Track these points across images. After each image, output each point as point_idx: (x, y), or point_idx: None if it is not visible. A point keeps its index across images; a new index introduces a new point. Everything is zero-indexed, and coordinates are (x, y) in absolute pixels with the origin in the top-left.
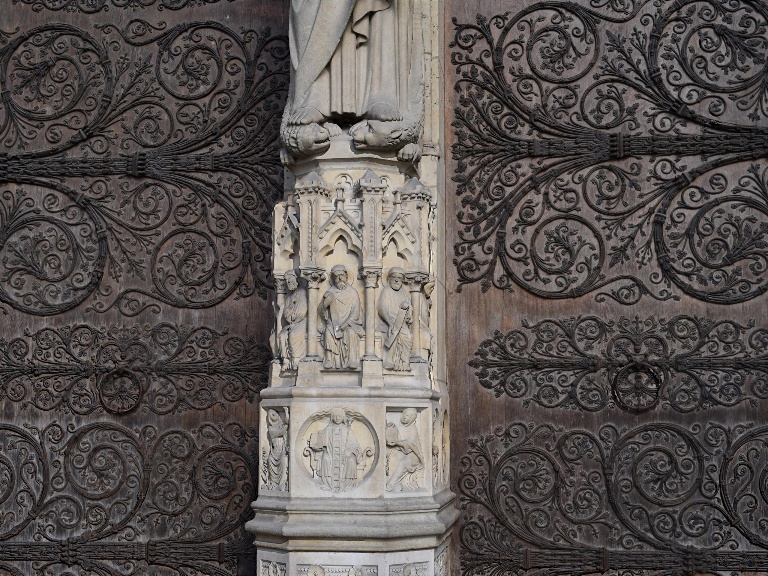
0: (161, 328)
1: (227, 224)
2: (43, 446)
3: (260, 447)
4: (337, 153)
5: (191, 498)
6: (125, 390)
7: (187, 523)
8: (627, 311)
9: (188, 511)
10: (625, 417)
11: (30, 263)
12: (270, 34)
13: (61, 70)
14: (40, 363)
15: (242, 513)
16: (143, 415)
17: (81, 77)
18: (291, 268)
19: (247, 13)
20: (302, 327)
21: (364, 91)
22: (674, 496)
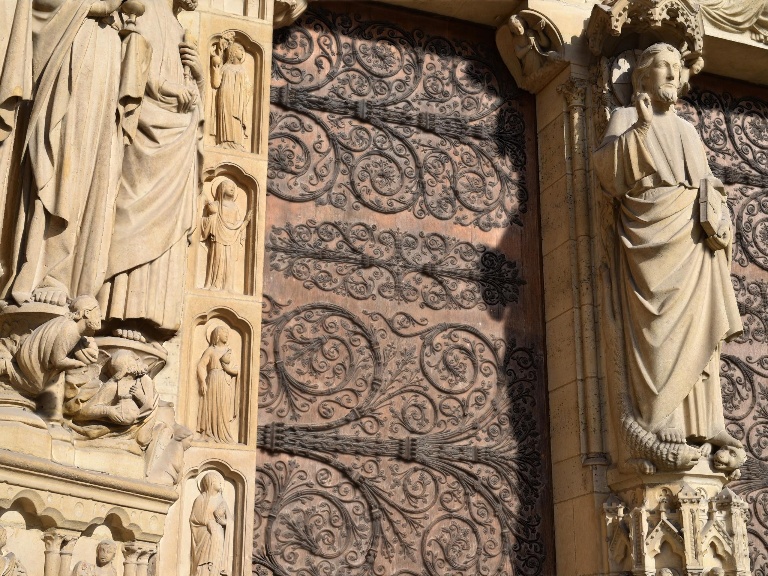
0: None
1: (487, 513)
2: None
3: None
4: (700, 470)
5: None
6: None
7: None
8: None
9: None
10: None
11: (305, 537)
12: (516, 345)
13: (332, 348)
14: None
15: None
16: None
17: (353, 358)
18: (654, 566)
19: (496, 323)
20: None
21: (706, 419)
22: None
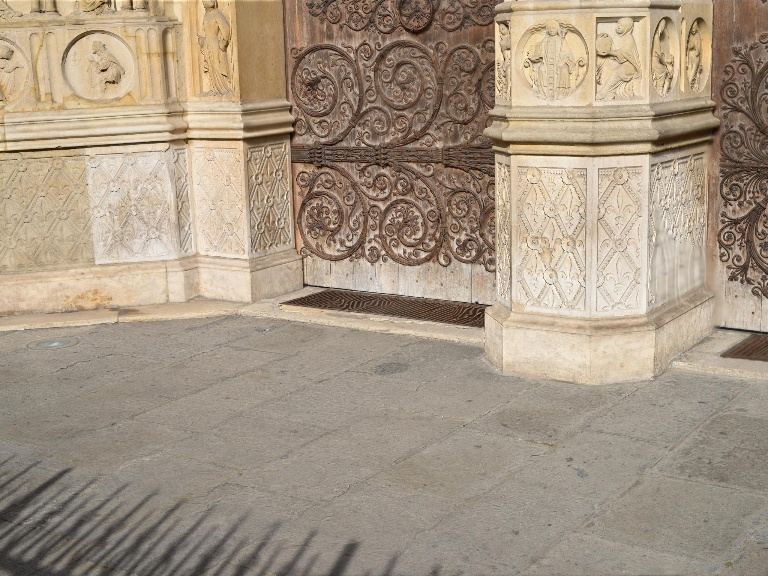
0: None
1: None
2: (357, 63)
3: (495, 60)
4: None
5: (477, 108)
6: (419, 10)
7: (475, 131)
8: None
9: (475, 120)
10: None
11: None
12: None
13: None
14: None
15: None
16: (435, 32)
17: None
18: None
19: None
20: None
21: None
22: None
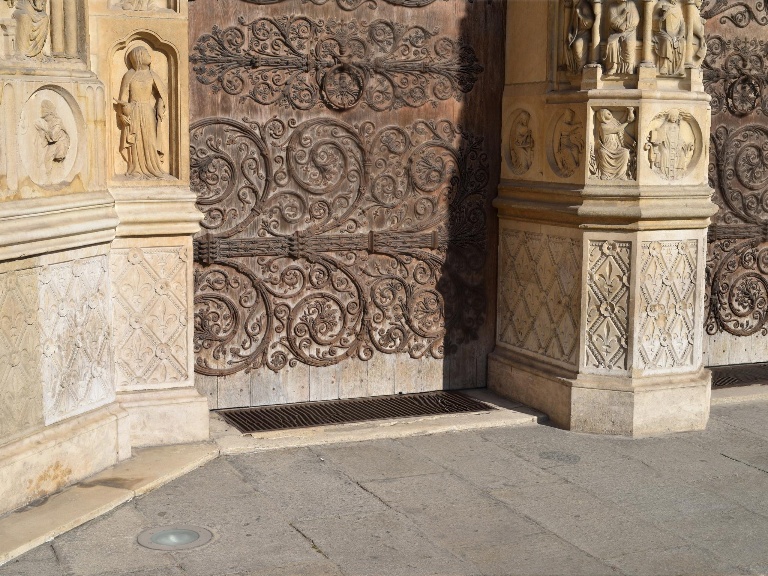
0: (378, 25)
1: None
2: (266, 141)
3: (589, 142)
4: None
5: (408, 191)
6: (346, 86)
7: (403, 214)
8: (740, 33)
9: (404, 203)
10: (733, 120)
11: None
12: None
13: None
14: (259, 55)
15: (453, 204)
16: (362, 111)
17: None
18: None
19: None
20: (635, 36)
21: None
22: (759, 182)
